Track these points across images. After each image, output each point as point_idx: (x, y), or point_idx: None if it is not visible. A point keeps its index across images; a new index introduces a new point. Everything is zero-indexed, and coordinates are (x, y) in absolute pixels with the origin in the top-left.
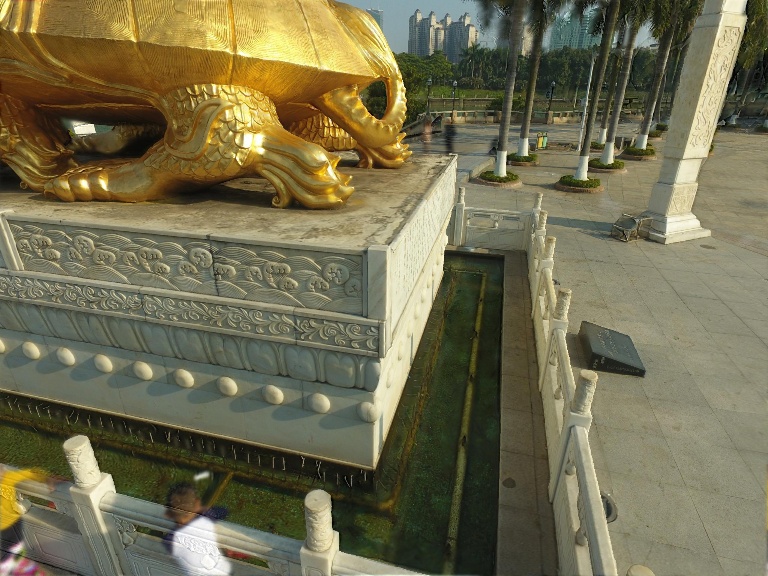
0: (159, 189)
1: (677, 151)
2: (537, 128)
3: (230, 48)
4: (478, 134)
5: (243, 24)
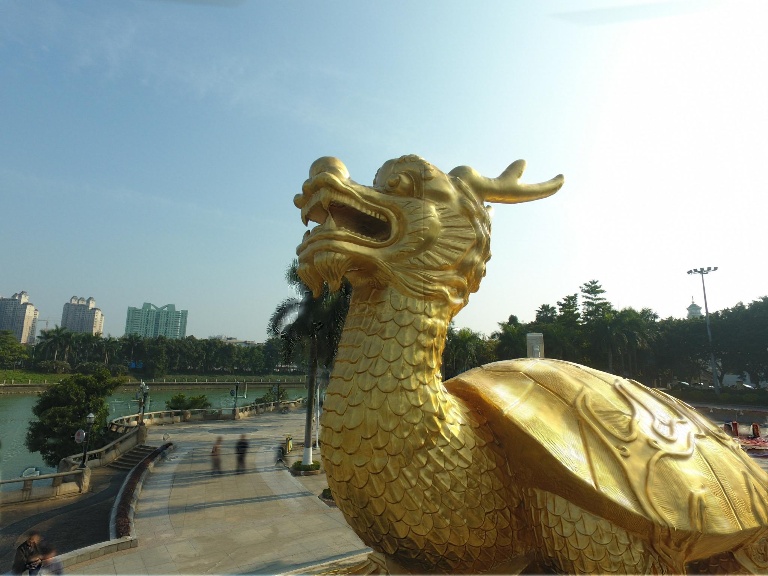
0: None
1: None
2: (238, 426)
3: None
4: (204, 441)
5: None
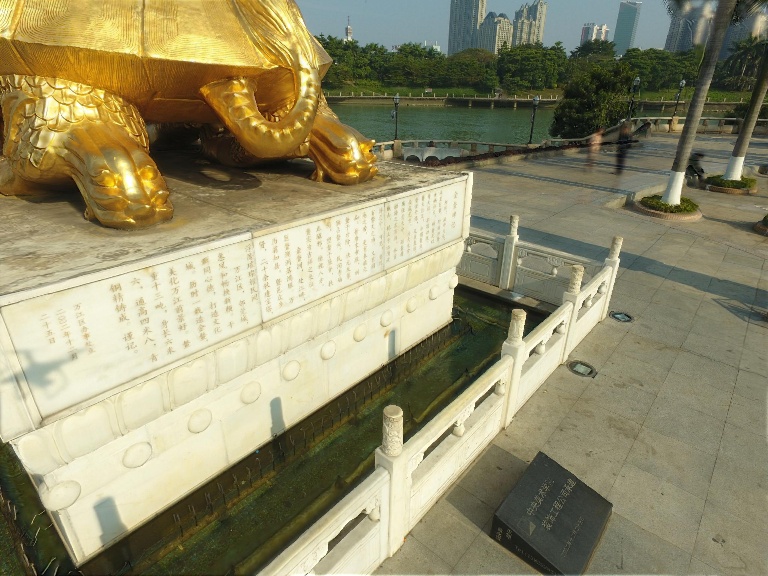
0: (22, 185)
1: None
2: None
3: (8, 32)
4: None
5: (35, 4)
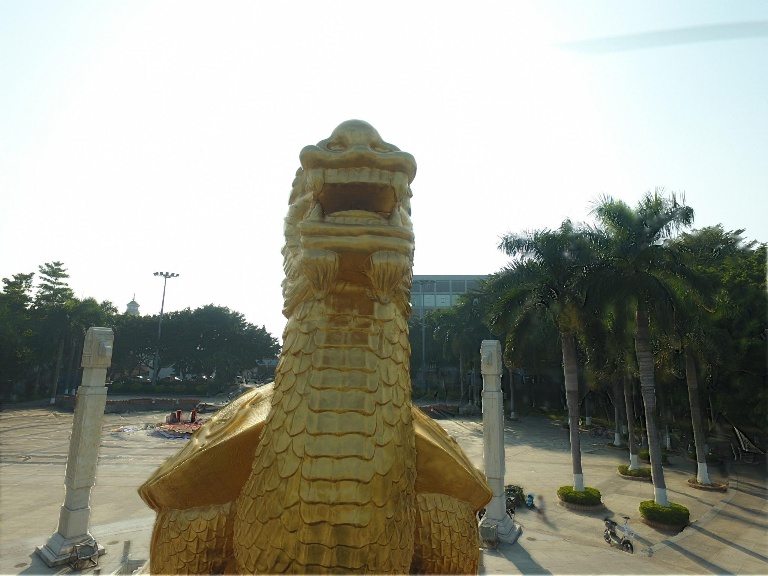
0: None
1: (88, 481)
2: None
3: None
4: None
5: None
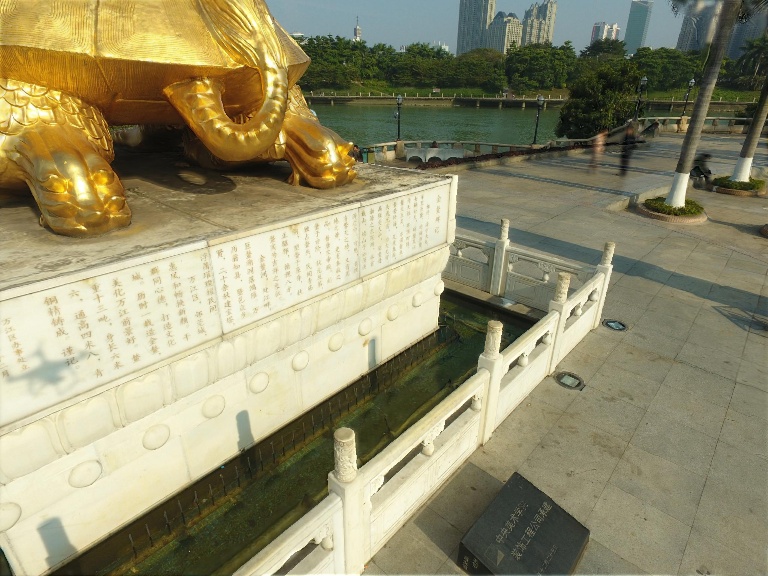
0: None
1: None
2: None
3: None
4: (701, 147)
5: None
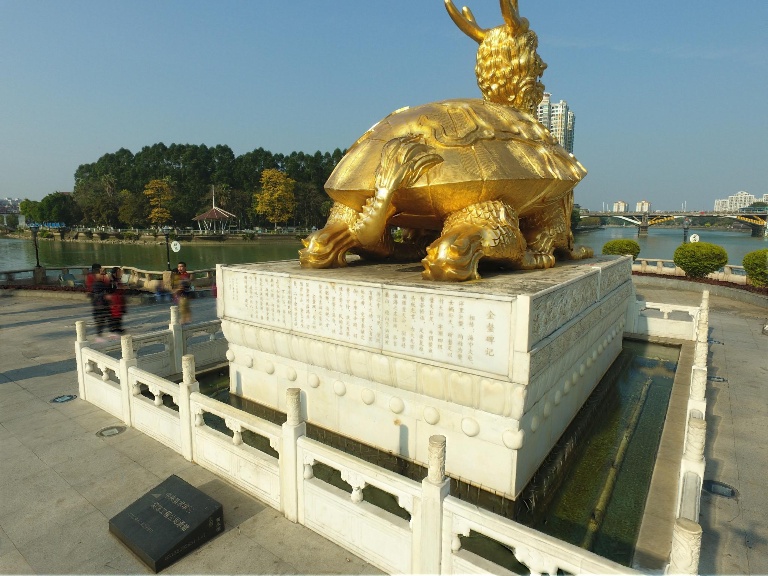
0: None
1: None
2: None
3: None
4: None
5: None
